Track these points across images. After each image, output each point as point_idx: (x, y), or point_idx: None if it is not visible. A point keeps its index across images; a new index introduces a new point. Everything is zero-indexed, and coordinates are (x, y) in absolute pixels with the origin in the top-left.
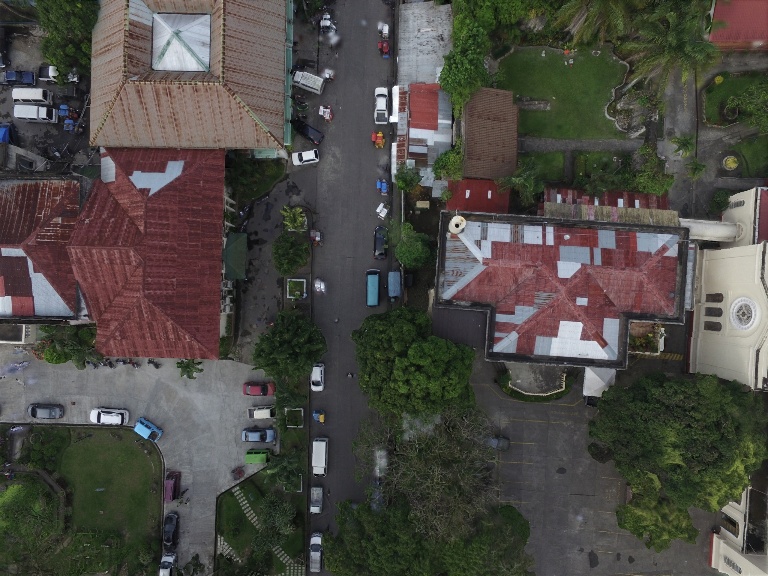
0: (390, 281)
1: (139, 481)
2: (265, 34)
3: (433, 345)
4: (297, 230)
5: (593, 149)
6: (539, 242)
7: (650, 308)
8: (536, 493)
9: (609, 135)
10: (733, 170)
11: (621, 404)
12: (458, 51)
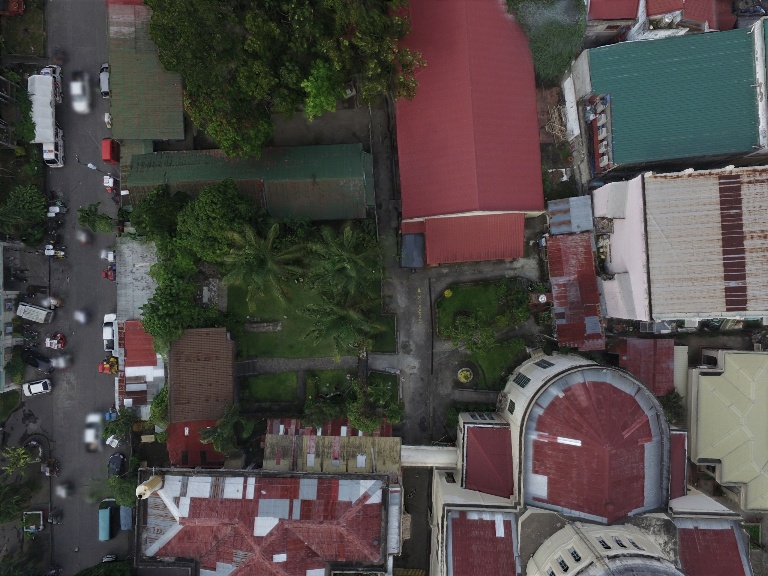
0: (121, 514)
1: None
2: None
3: None
4: (22, 470)
5: (326, 367)
6: (238, 496)
7: (355, 556)
8: None
9: (342, 352)
10: (469, 381)
11: None
12: (149, 307)
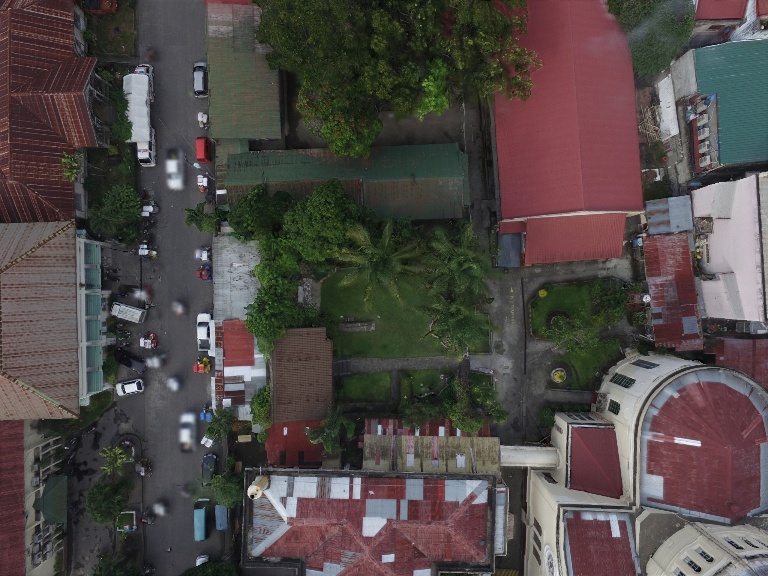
0: (217, 514)
1: None
2: (51, 308)
3: None
4: (118, 470)
5: (420, 367)
6: (345, 496)
7: (461, 557)
8: None
9: (436, 352)
10: (562, 382)
11: None
12: (256, 306)
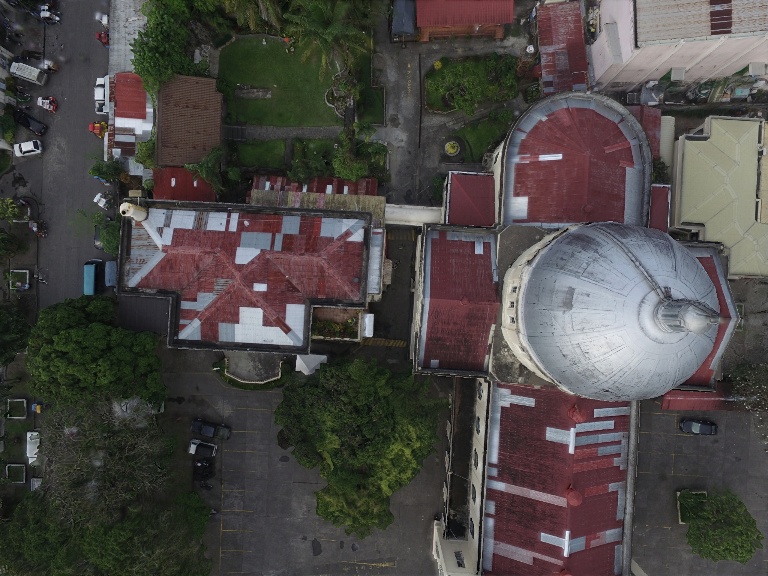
0: (106, 271)
1: None
2: None
3: (86, 332)
4: None
5: (314, 136)
6: (221, 228)
7: (335, 293)
8: (259, 482)
9: (330, 122)
10: (456, 155)
11: (292, 389)
12: (139, 39)
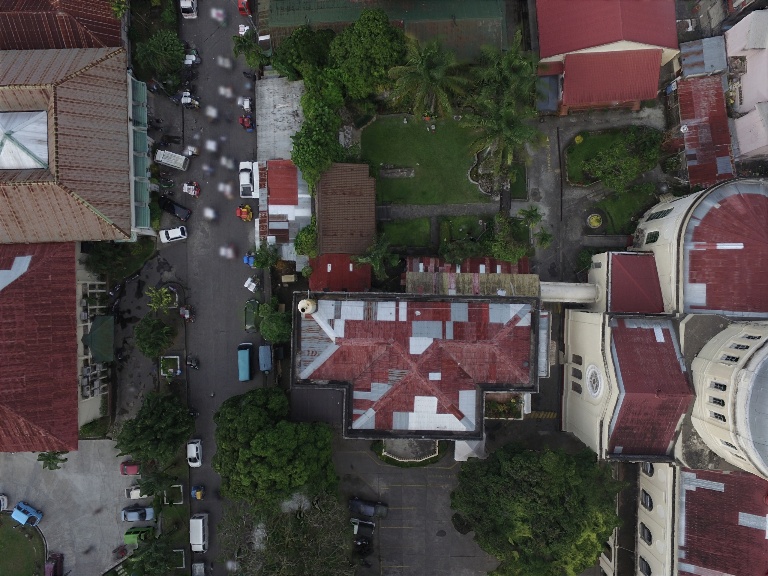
0: (260, 355)
1: (22, 565)
2: (104, 127)
3: (278, 433)
4: (164, 310)
5: (459, 213)
6: (392, 318)
7: (505, 378)
8: (417, 557)
9: (474, 199)
10: (598, 227)
11: (475, 478)
12: (303, 132)
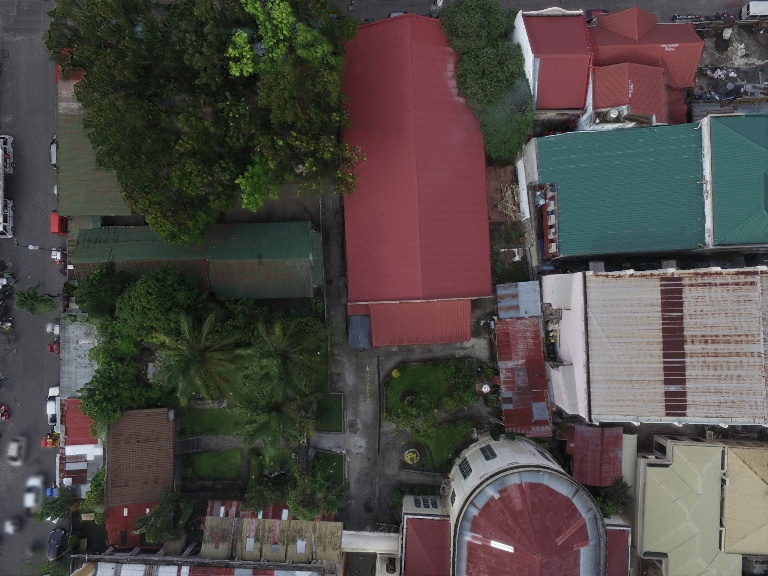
0: None
1: None
2: None
3: None
4: None
5: None
6: None
7: None
8: None
9: None
10: (416, 463)
11: None
12: (86, 391)
